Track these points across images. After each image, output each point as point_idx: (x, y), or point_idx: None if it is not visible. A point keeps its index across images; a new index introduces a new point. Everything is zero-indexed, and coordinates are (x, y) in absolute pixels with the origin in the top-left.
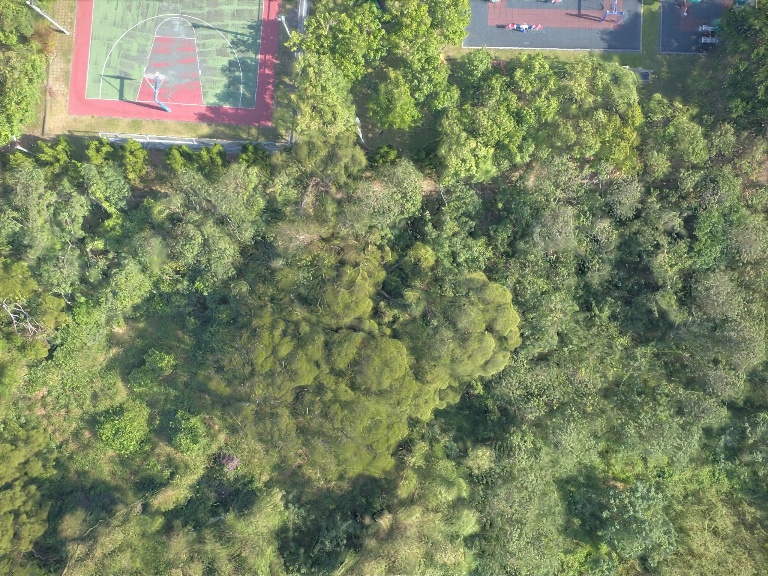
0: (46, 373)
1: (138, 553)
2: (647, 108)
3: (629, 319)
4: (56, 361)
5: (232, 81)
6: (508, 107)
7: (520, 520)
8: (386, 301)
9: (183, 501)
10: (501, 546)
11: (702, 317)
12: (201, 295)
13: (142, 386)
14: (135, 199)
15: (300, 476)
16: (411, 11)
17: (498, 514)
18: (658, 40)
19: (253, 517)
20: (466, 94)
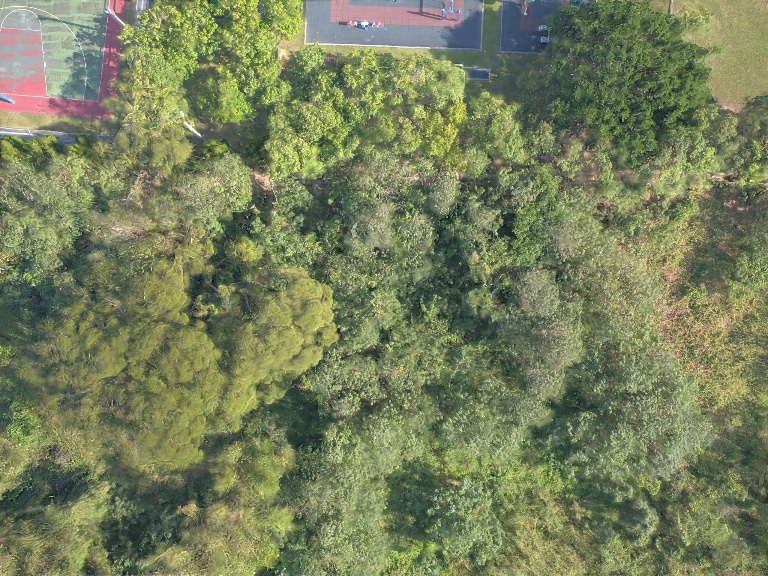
0: None
1: None
2: (472, 106)
3: (459, 317)
4: None
5: (76, 74)
6: (334, 103)
7: (336, 516)
8: (205, 294)
9: (14, 493)
10: (319, 542)
11: (520, 315)
12: None
13: None
14: None
15: (134, 470)
16: (240, 6)
17: (315, 510)
18: (498, 39)
19: None
20: (297, 89)
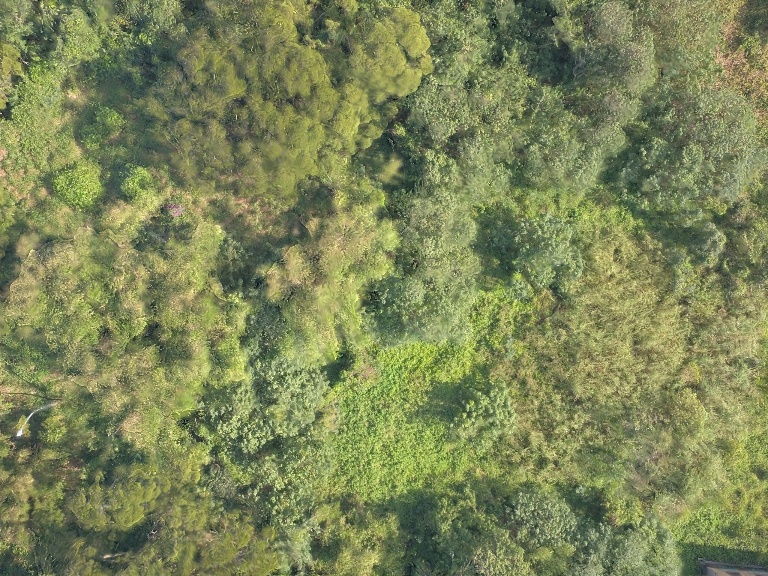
0: (5, 129)
1: (85, 258)
2: None
3: (537, 64)
4: (14, 120)
5: None
6: None
7: (436, 233)
8: (311, 35)
9: (132, 244)
10: (420, 260)
11: (597, 44)
12: (147, 52)
13: (93, 140)
14: None
15: (240, 223)
16: None
17: (416, 229)
18: None
19: None
20: None
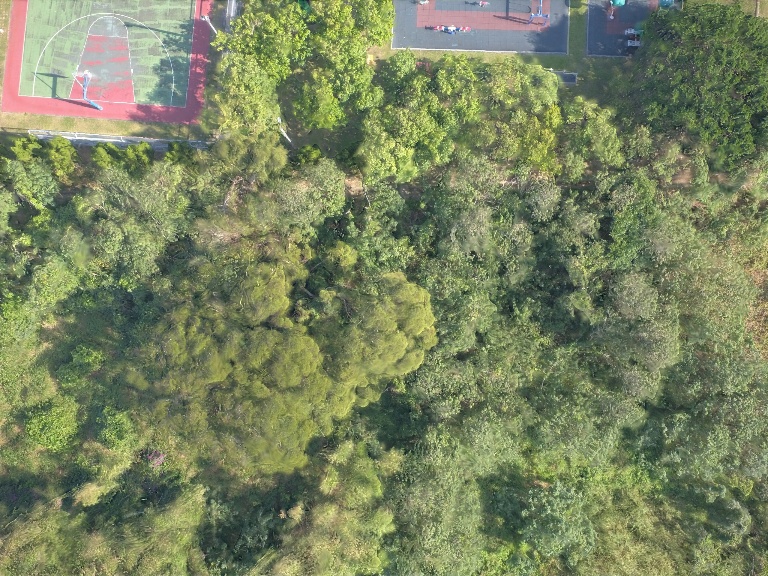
0: None
1: (54, 547)
2: (567, 110)
3: (550, 319)
4: None
5: (164, 80)
6: (429, 108)
7: (436, 518)
8: (304, 299)
9: (108, 496)
10: (418, 543)
11: (617, 318)
12: (127, 292)
13: (69, 382)
14: (64, 196)
15: (226, 472)
16: (334, 12)
17: (414, 512)
18: (585, 43)
19: (172, 512)
20: (390, 95)
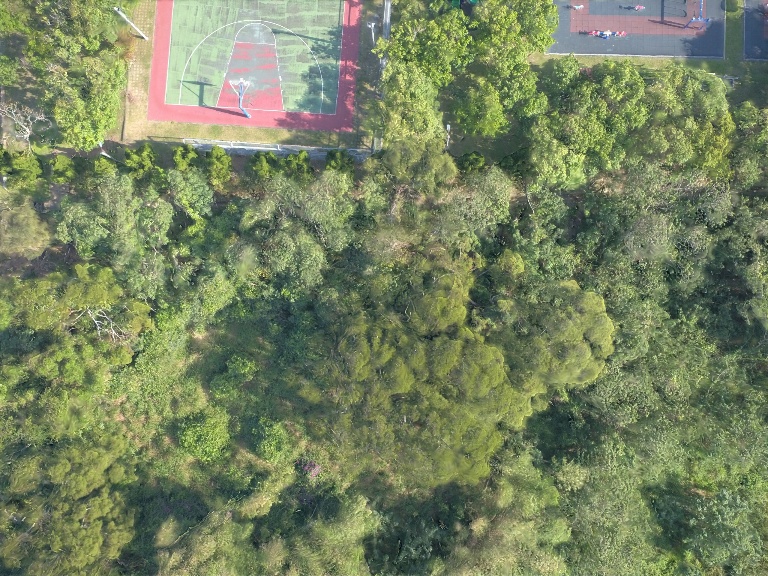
0: (128, 379)
1: (232, 561)
2: (738, 116)
3: (715, 326)
4: (137, 367)
5: (313, 87)
6: (598, 114)
7: (611, 528)
8: (478, 309)
9: (266, 508)
10: (591, 554)
11: None
12: (285, 302)
13: (224, 393)
14: (218, 205)
15: (382, 483)
16: (500, 18)
17: (589, 522)
18: (741, 47)
19: (342, 525)
20: (554, 101)
